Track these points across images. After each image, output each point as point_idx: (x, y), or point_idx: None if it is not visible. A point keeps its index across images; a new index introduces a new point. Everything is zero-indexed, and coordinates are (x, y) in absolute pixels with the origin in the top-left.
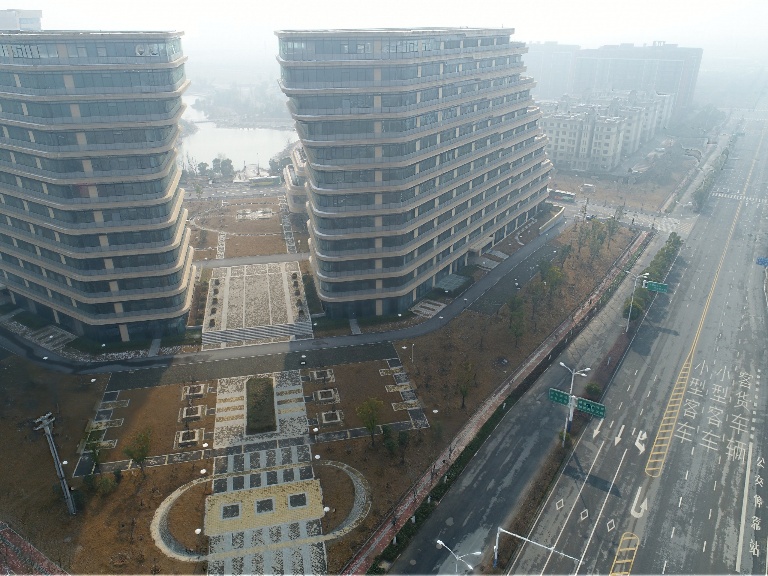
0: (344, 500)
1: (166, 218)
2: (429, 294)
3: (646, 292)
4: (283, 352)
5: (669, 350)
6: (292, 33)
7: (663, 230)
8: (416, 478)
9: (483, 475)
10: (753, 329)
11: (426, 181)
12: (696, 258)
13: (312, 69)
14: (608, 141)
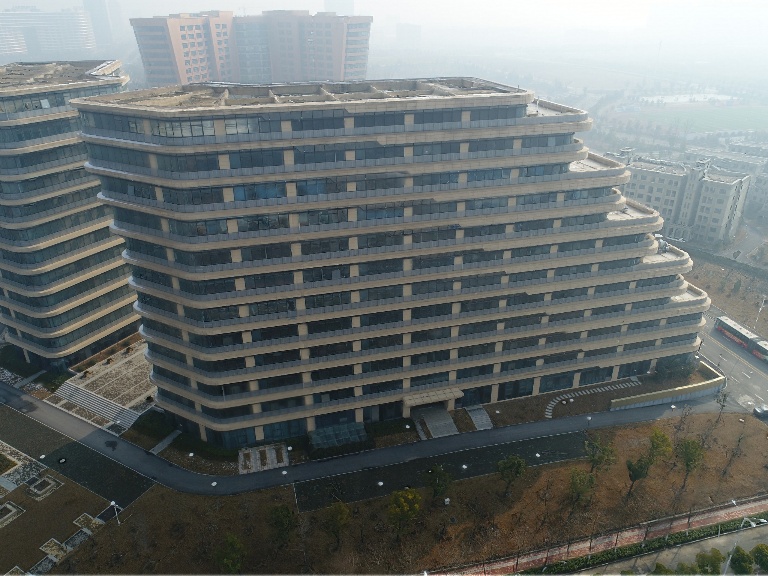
0: None
1: (35, 266)
2: (293, 439)
3: None
4: (74, 438)
5: None
6: None
7: None
8: None
9: None
10: None
11: (261, 302)
12: None
13: (96, 144)
14: None
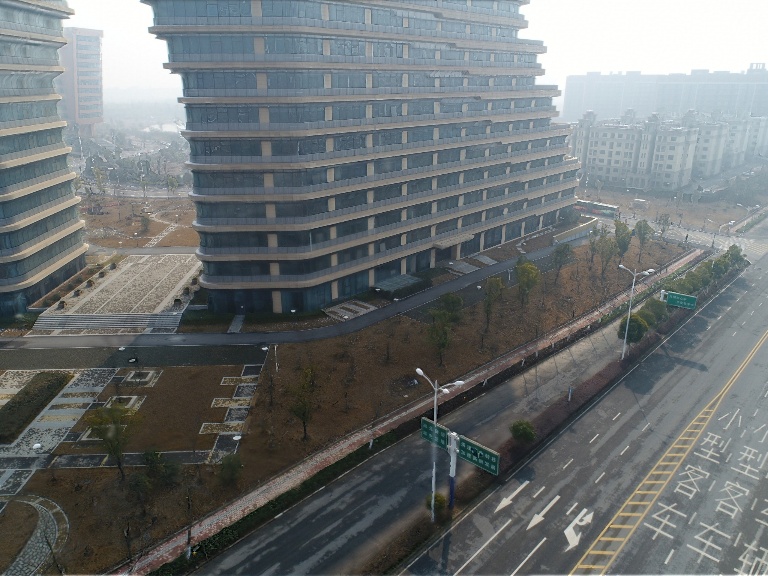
0: None
1: None
2: (361, 294)
3: (661, 305)
4: (119, 345)
5: (683, 389)
6: None
7: (727, 249)
8: (147, 544)
9: (266, 553)
10: None
11: (345, 134)
12: (765, 281)
13: None
14: (672, 153)
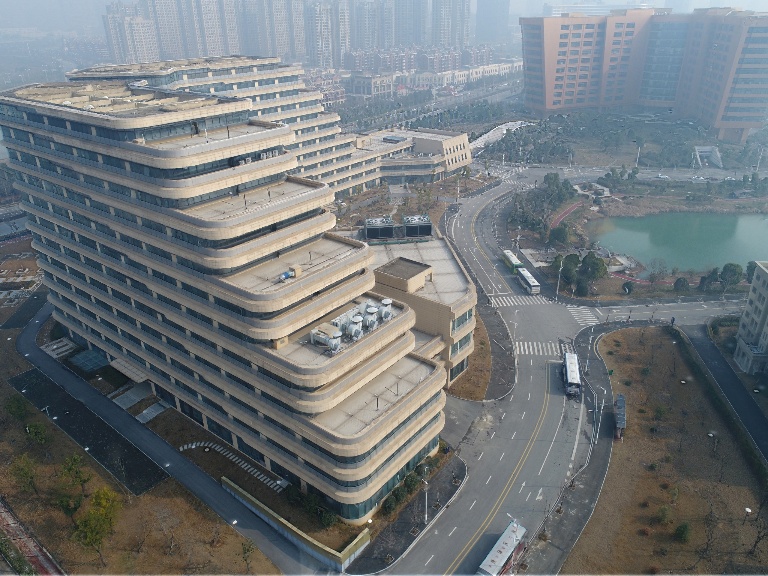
0: None
1: None
2: (81, 348)
3: None
4: None
5: None
6: None
7: None
8: None
9: None
10: None
11: None
12: None
13: None
14: None
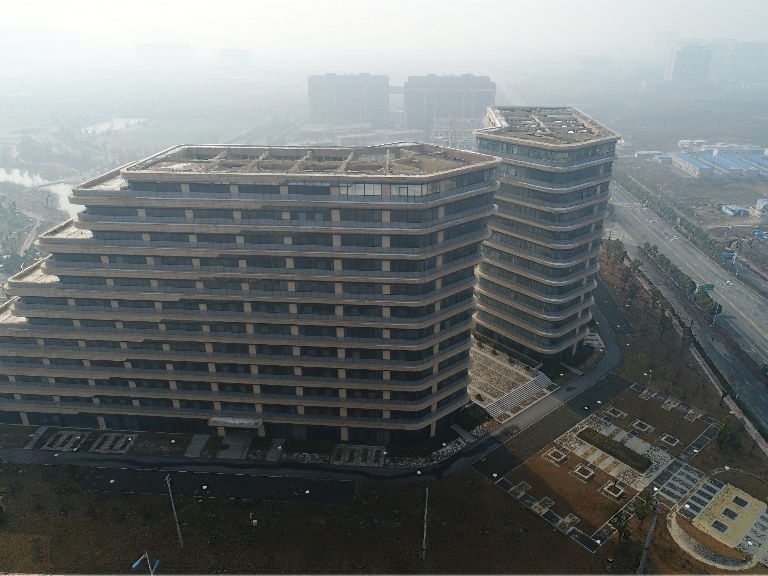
0: (766, 489)
1: None
2: None
3: None
4: (560, 404)
5: (747, 330)
6: (570, 146)
7: None
8: None
9: None
10: (761, 303)
11: None
12: None
13: (573, 172)
14: None
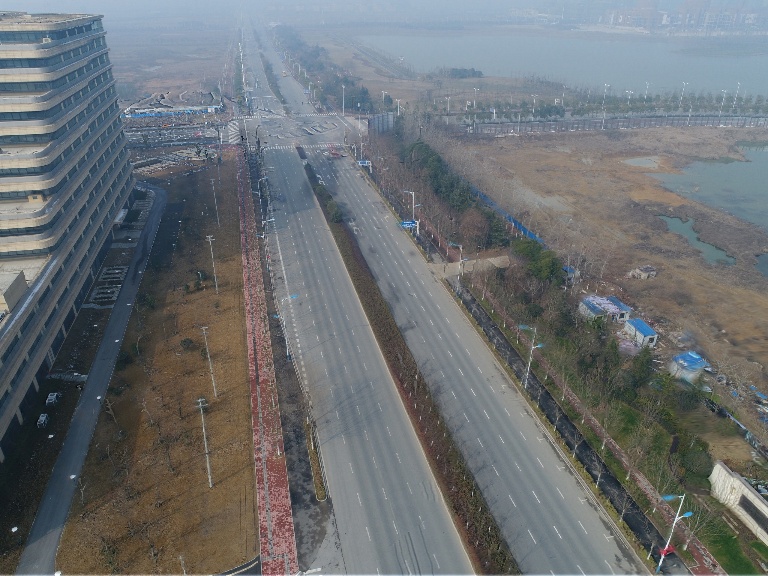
0: None
1: None
2: None
3: None
4: None
5: None
6: None
7: None
8: None
9: None
10: None
11: None
12: None
13: None
14: None
